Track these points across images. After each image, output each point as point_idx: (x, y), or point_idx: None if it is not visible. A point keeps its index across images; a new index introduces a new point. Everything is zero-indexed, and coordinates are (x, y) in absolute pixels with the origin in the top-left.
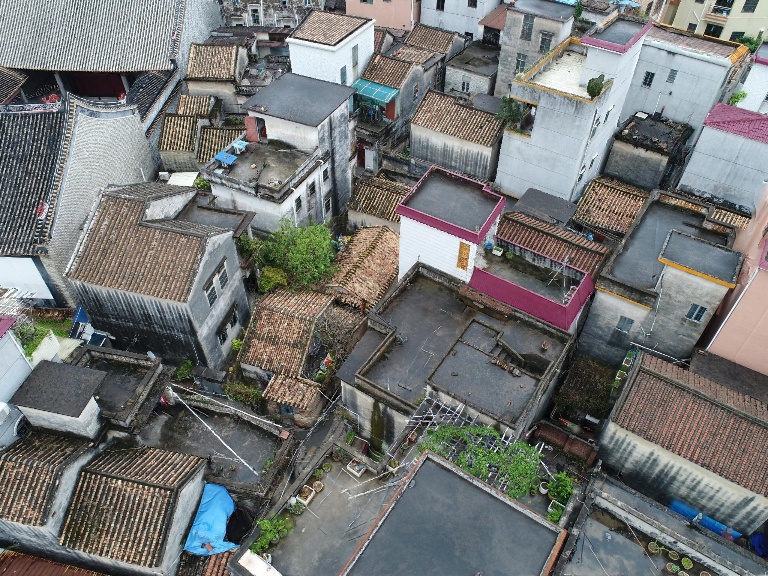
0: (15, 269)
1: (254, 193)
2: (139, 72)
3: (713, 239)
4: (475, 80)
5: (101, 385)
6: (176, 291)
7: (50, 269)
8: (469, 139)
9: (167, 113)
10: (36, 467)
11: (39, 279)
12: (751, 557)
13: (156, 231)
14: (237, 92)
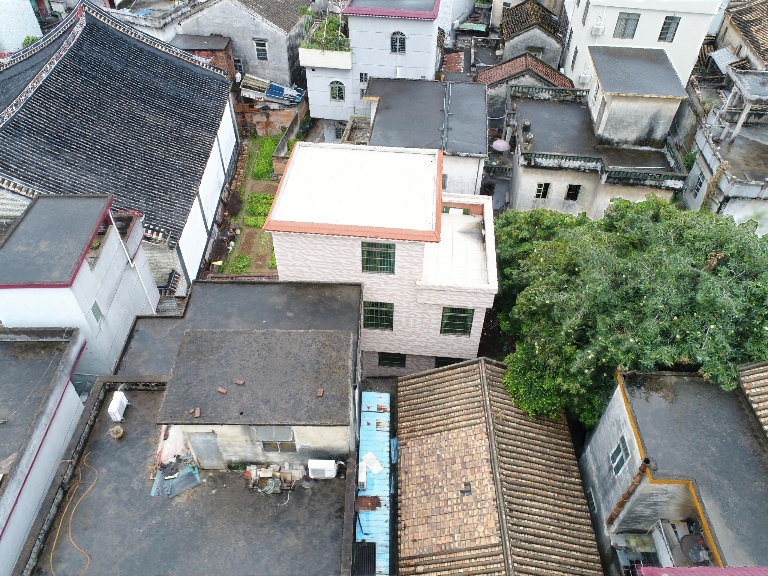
0: None
1: (189, 9)
2: None
3: None
4: None
5: None
6: (305, 2)
7: None
8: None
9: None
10: None
11: None
12: None
13: None
14: None
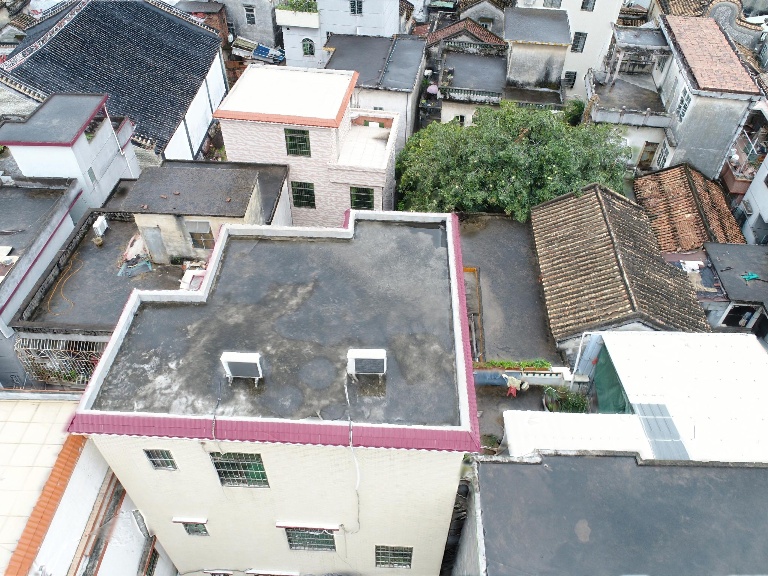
0: None
1: None
2: None
3: None
4: None
5: None
6: None
7: None
8: None
9: None
10: None
11: (221, 73)
12: None
13: None
14: (11, 13)
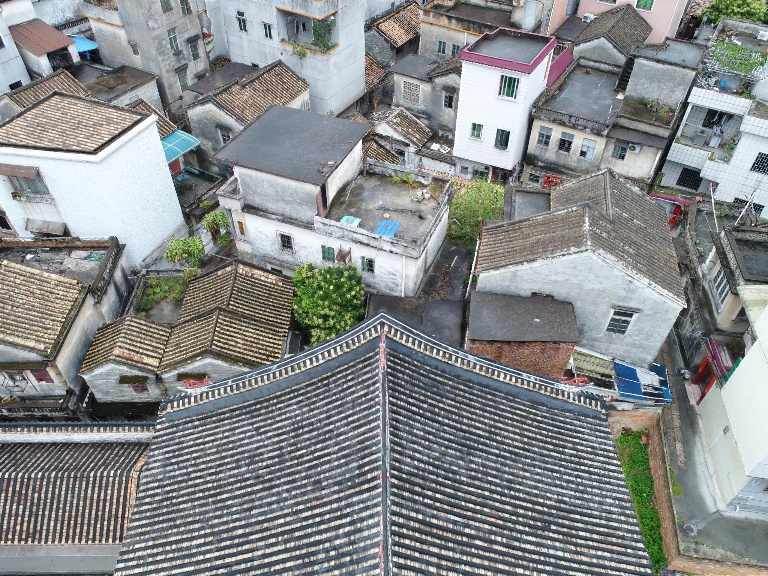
0: None
1: None
2: None
3: (461, 7)
4: (143, 93)
5: (764, 273)
6: None
7: None
8: (296, 96)
9: (199, 352)
10: None
11: None
12: (701, 29)
13: None
14: (99, 298)
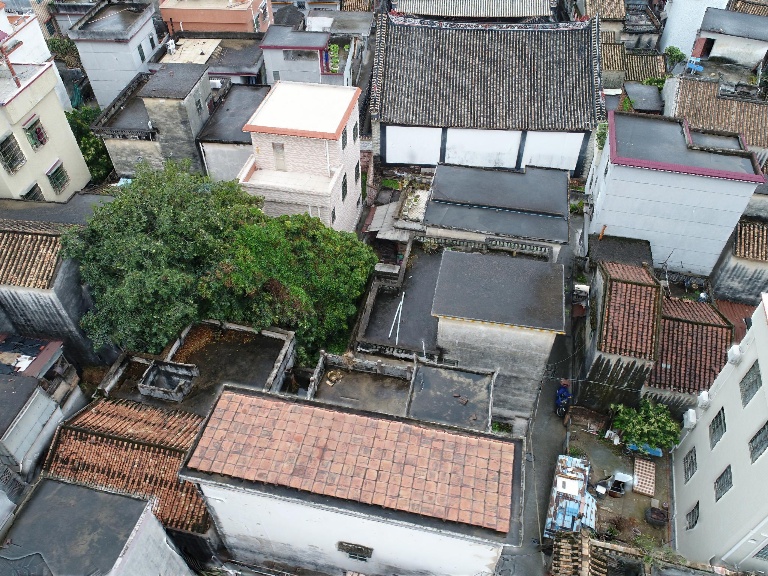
0: (564, 143)
1: (733, 91)
2: (522, 18)
3: None
4: None
5: None
6: (763, 140)
7: (591, 143)
8: None
9: None
10: (767, 229)
11: (576, 152)
12: None
13: (732, 102)
14: (624, 30)
